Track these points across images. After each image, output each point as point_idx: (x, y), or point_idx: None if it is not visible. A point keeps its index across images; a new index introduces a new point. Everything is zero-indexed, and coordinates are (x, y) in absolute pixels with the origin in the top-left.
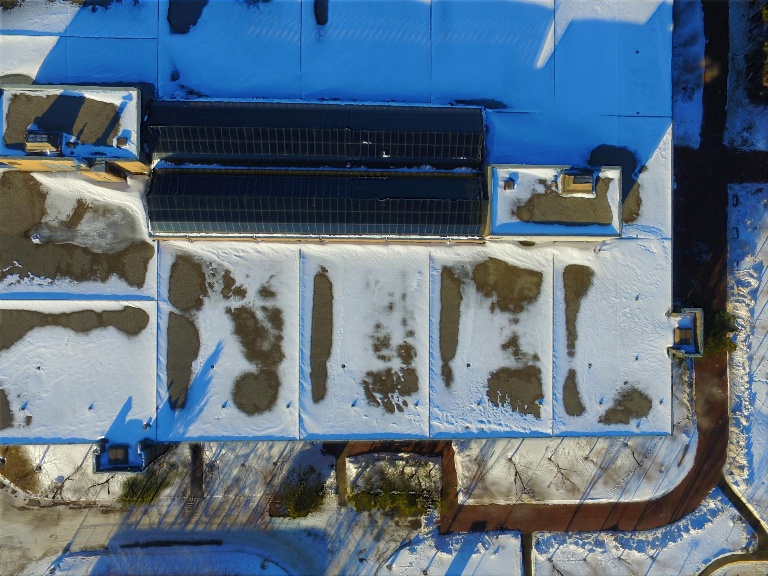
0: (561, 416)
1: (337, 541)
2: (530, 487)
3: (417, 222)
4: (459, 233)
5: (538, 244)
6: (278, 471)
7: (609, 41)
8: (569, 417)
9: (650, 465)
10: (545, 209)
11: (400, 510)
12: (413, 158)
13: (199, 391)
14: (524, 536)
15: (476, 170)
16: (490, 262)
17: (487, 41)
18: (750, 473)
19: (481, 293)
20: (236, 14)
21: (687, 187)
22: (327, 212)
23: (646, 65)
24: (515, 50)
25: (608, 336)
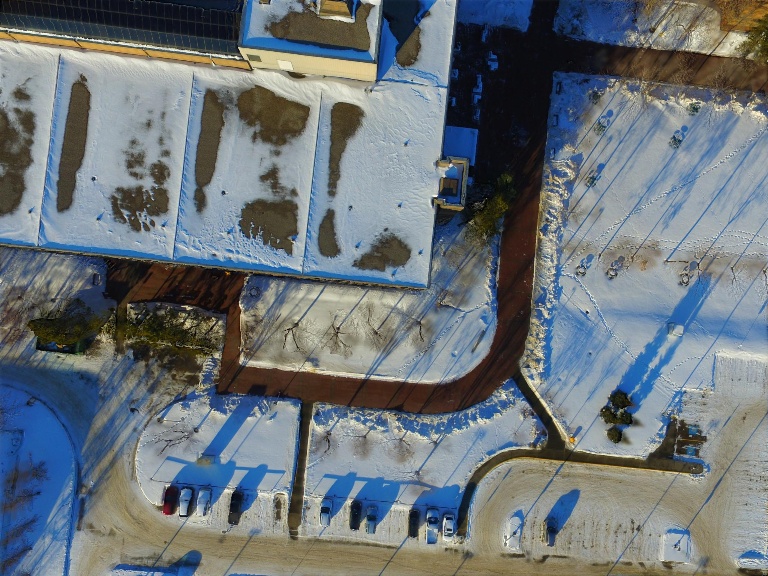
0: (314, 255)
1: (110, 388)
2: (315, 355)
3: (171, 31)
4: (218, 50)
5: (307, 77)
6: (56, 308)
7: None
8: (322, 257)
9: (443, 347)
10: (301, 28)
11: (179, 364)
12: None
13: None
14: (304, 405)
15: None
16: (256, 90)
17: None
18: (546, 367)
19: (244, 121)
20: None
21: (510, 70)
22: (76, 8)
23: None
24: None
25: (372, 180)
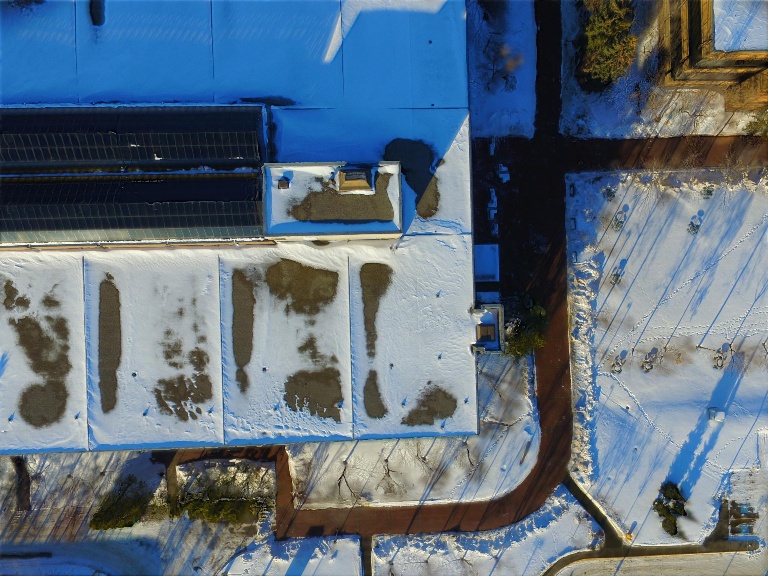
0: (362, 418)
1: (170, 550)
2: (367, 490)
3: (193, 225)
4: (242, 235)
5: (332, 243)
6: (106, 481)
7: (400, 32)
8: (370, 419)
9: (491, 464)
10: (323, 208)
11: None
12: (188, 160)
13: None
14: (363, 540)
15: (258, 170)
16: (283, 263)
17: (272, 36)
18: (595, 469)
19: (275, 295)
20: (8, 18)
21: (522, 178)
22: (96, 218)
23: (440, 55)
24: (302, 44)
25: (409, 335)
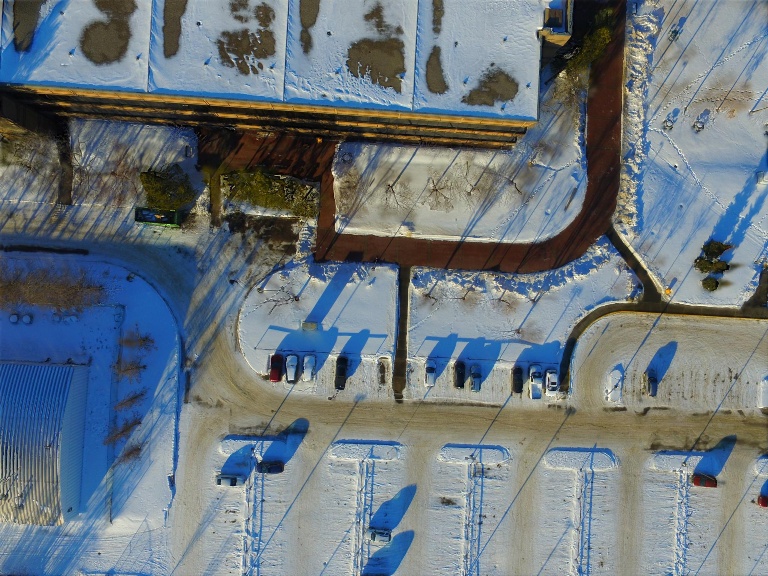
0: (423, 92)
1: (208, 260)
2: (410, 219)
3: None
4: None
5: None
6: None
7: None
8: (431, 94)
9: (536, 206)
10: None
11: (275, 234)
12: None
13: (46, 36)
14: (402, 270)
15: None
16: None
17: None
18: (639, 221)
19: None
20: None
21: None
22: None
23: None
24: None
25: (476, 15)
